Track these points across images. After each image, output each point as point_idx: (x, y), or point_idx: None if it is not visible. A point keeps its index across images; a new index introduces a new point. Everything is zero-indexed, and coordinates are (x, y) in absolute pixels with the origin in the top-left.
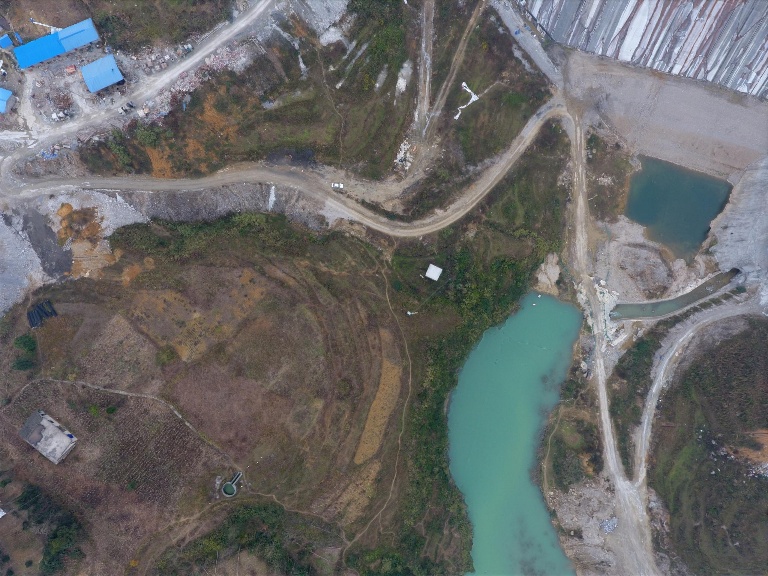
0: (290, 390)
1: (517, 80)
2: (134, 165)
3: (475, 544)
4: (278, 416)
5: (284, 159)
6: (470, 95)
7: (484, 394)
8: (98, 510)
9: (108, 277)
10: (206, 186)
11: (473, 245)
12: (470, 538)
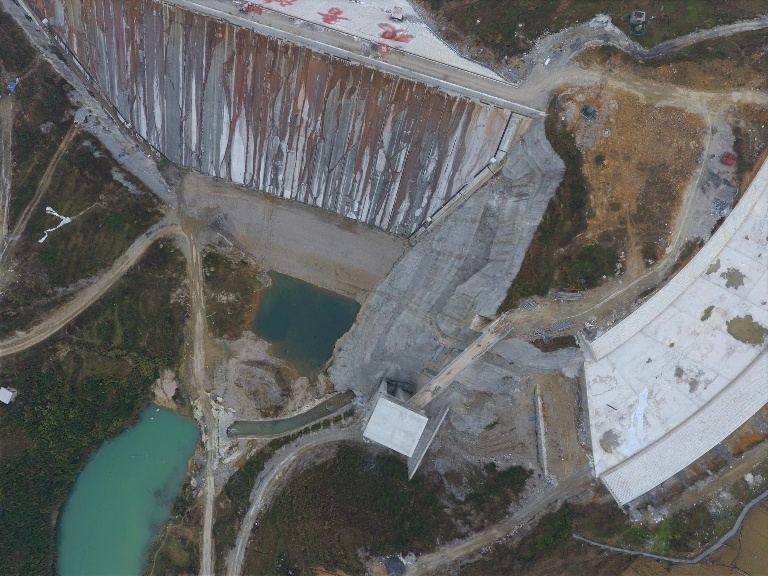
0: None
1: (118, 202)
2: None
3: None
4: None
5: None
6: (59, 218)
7: (100, 506)
8: None
9: None
10: None
11: (63, 365)
12: None
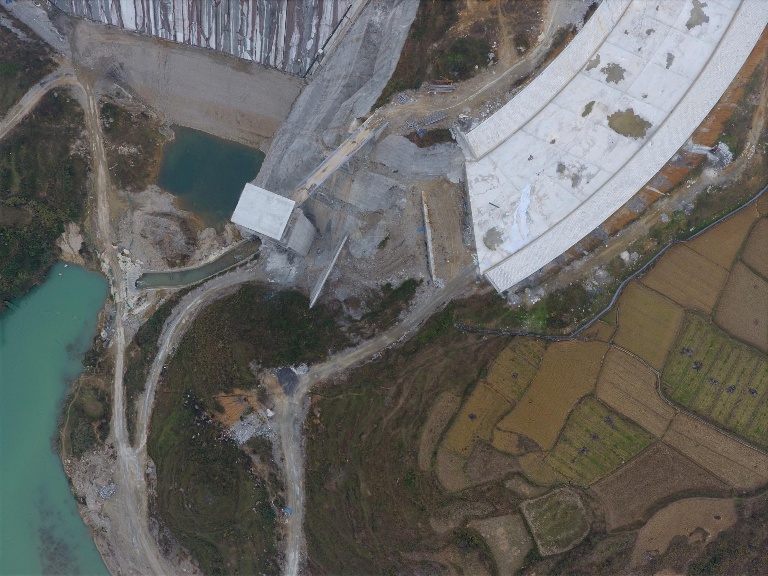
0: None
1: (7, 49)
2: None
3: None
4: None
5: None
6: None
7: (14, 364)
8: None
9: None
10: None
11: None
12: None
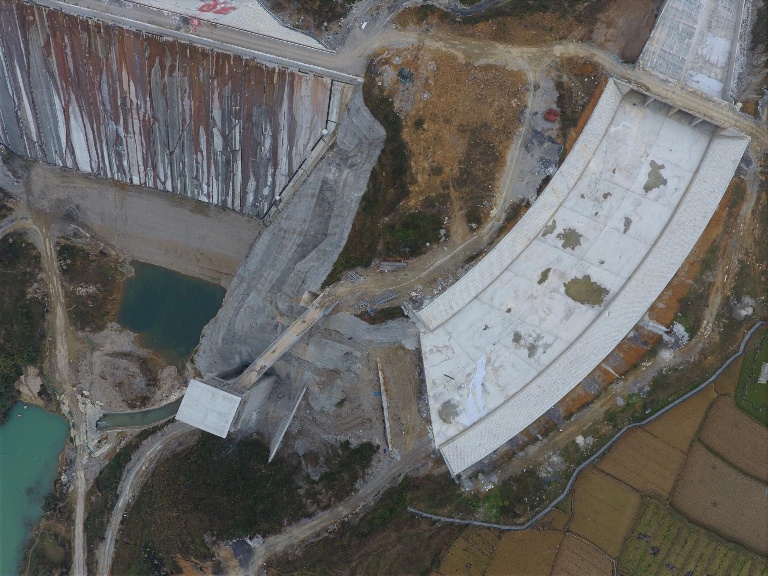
0: None
1: None
2: None
3: None
4: None
5: None
6: None
7: None
8: None
9: None
10: None
11: None
12: None
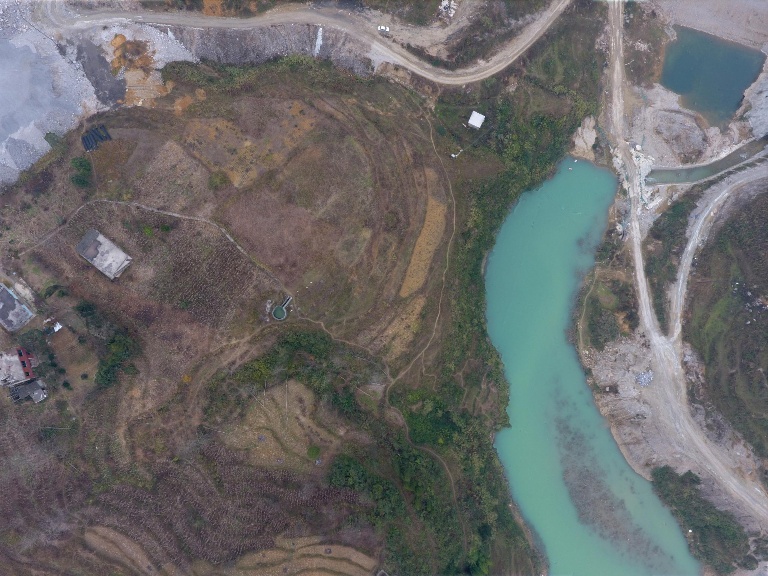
0: (339, 218)
1: None
2: (185, 1)
3: (511, 403)
4: (327, 243)
5: (331, 2)
6: None
7: (520, 258)
8: (151, 328)
9: (161, 106)
10: (255, 25)
11: (514, 99)
12: (507, 395)
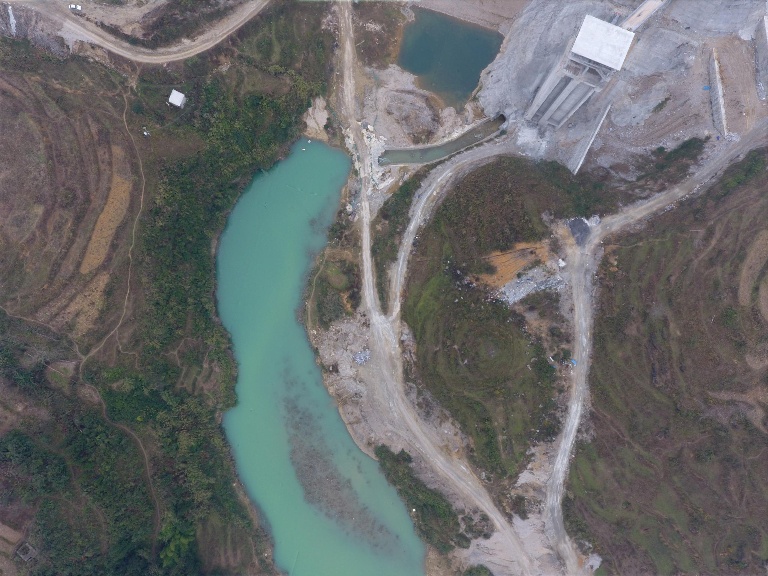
0: (8, 194)
1: None
2: None
3: (242, 383)
4: None
5: None
6: None
7: (255, 238)
8: None
9: None
10: None
11: (225, 78)
12: (233, 375)
